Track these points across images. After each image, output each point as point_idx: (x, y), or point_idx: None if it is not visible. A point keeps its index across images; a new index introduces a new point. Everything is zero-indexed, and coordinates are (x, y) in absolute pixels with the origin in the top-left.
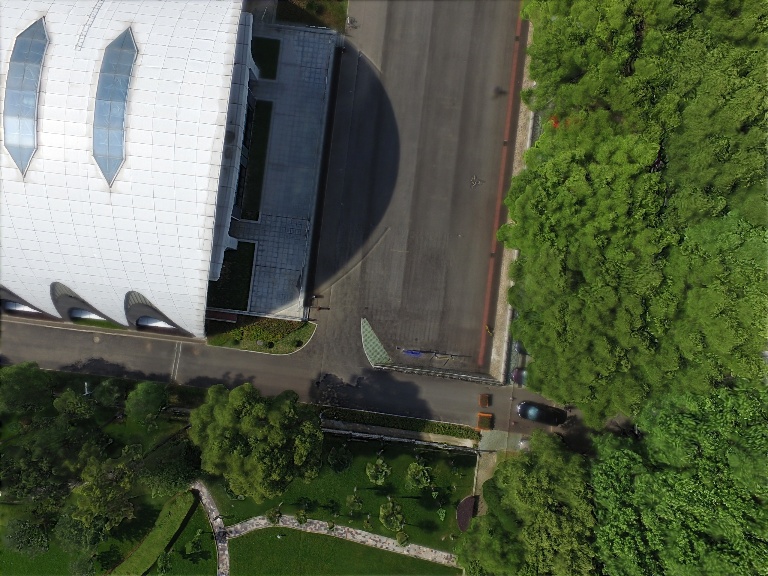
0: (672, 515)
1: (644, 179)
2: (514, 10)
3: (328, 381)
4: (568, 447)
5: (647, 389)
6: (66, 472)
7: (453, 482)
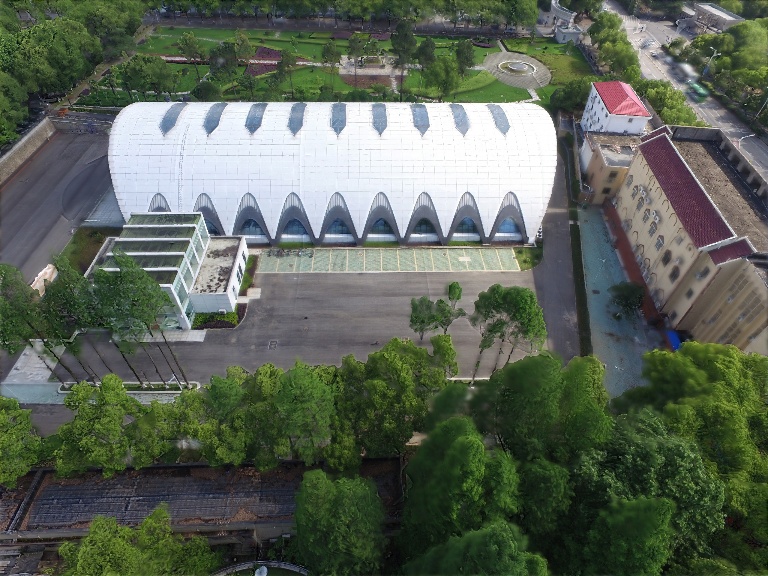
0: None
1: None
2: None
3: None
4: (20, 82)
5: None
6: None
7: None
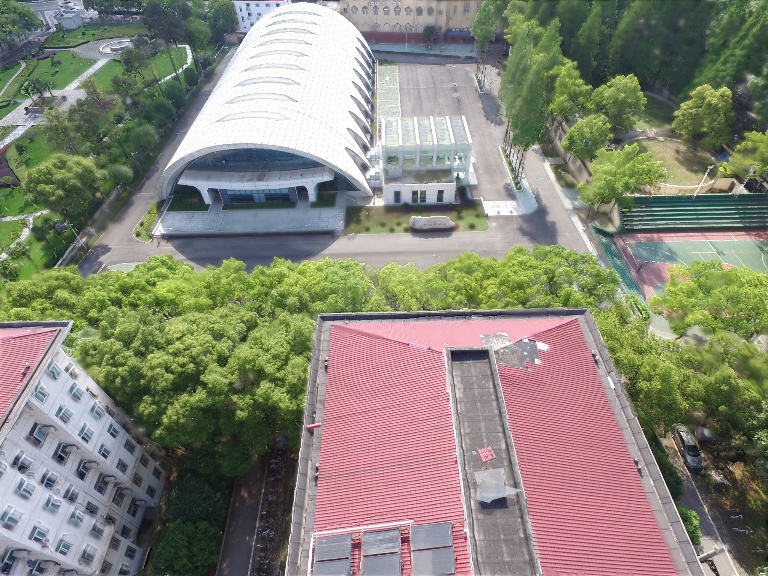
0: None
1: None
2: None
3: (107, 249)
4: None
5: None
6: None
7: None
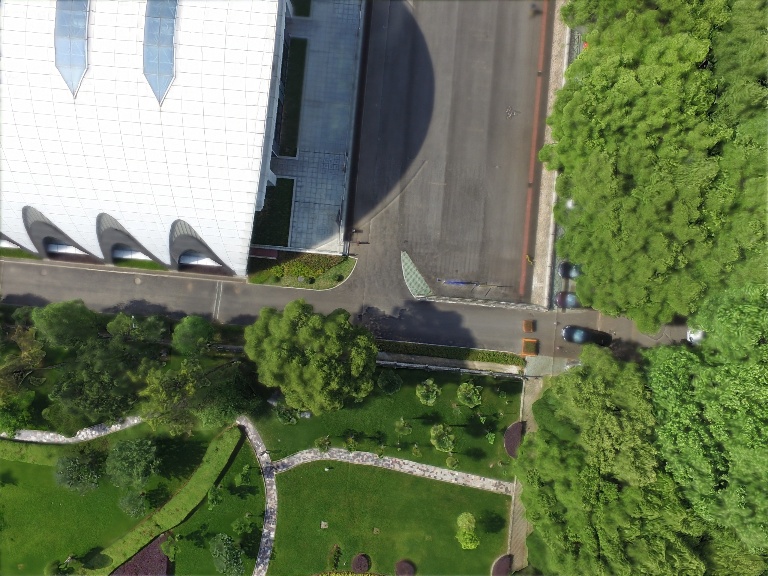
0: (738, 401)
1: (695, 75)
2: None
3: (370, 314)
4: None
5: (704, 285)
6: (127, 384)
7: (499, 409)
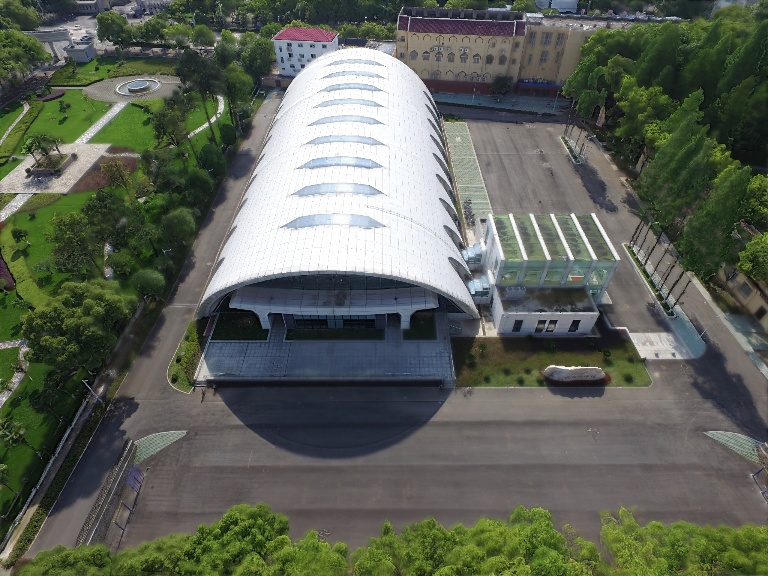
0: None
1: None
2: None
3: (132, 406)
4: None
5: None
6: None
7: None
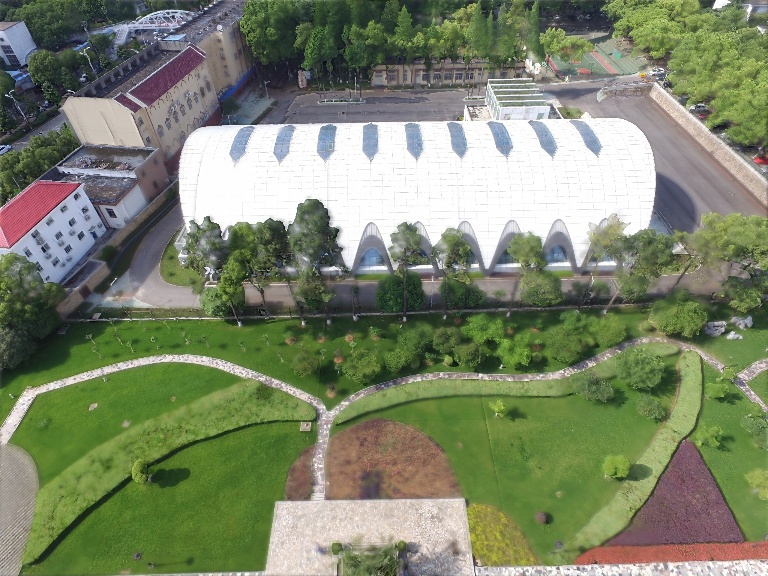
0: None
1: None
2: (691, 143)
3: None
4: None
5: None
6: None
7: None
